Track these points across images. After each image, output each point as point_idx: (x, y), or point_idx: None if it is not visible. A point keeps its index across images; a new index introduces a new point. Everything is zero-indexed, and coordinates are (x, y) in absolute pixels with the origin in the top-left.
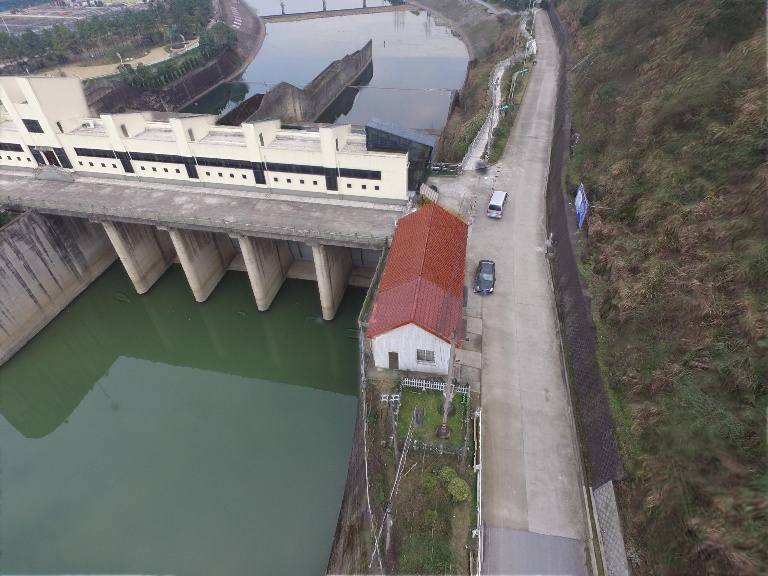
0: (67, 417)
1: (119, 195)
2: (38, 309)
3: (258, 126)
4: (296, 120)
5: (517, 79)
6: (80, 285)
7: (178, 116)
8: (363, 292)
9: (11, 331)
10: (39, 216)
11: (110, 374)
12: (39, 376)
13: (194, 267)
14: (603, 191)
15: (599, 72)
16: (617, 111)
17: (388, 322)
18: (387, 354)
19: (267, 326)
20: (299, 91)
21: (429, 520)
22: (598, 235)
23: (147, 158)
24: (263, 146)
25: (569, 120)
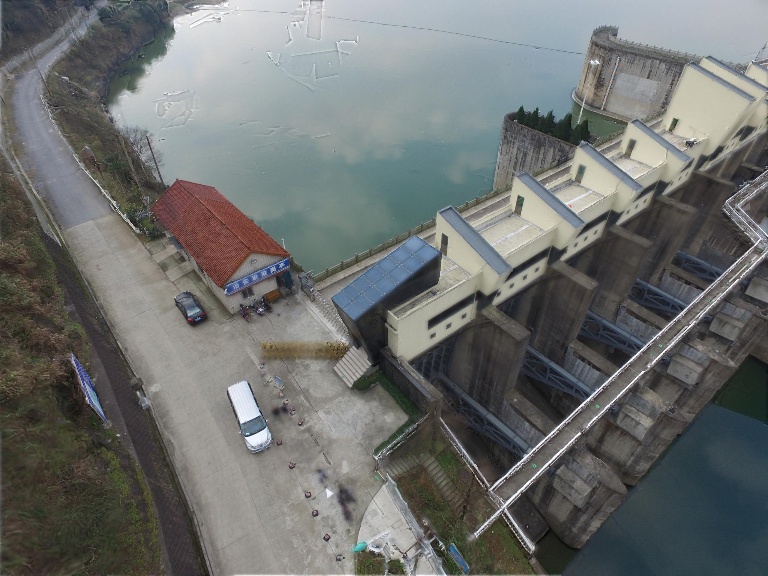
0: None
1: None
2: None
3: (522, 186)
4: None
5: None
6: None
7: None
8: None
9: None
10: None
11: None
12: None
13: None
14: None
15: None
16: None
17: None
18: None
19: None
20: None
21: None
22: None
23: None
24: None
25: None
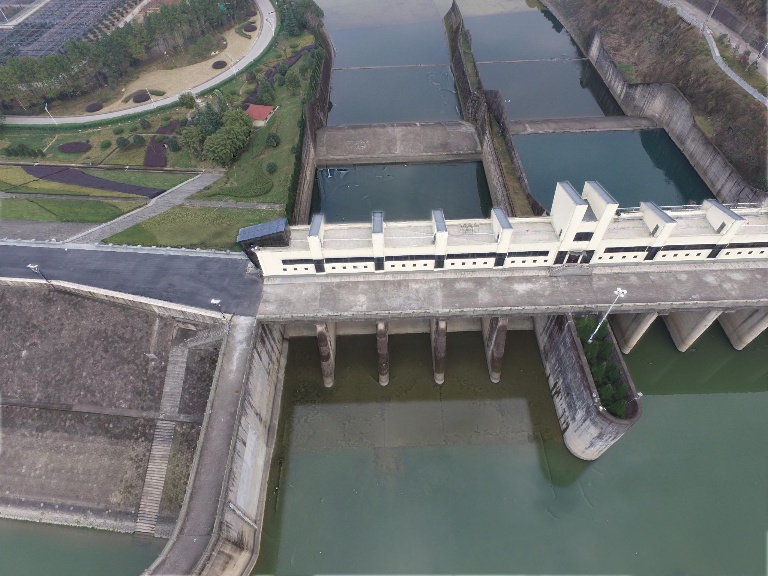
0: None
1: (654, 284)
2: None
3: None
4: None
5: None
6: None
7: (379, 134)
8: None
9: None
10: None
11: None
12: None
13: None
14: None
15: None
16: None
17: None
18: None
19: (729, 359)
20: None
21: None
22: None
23: (676, 248)
24: None
25: None
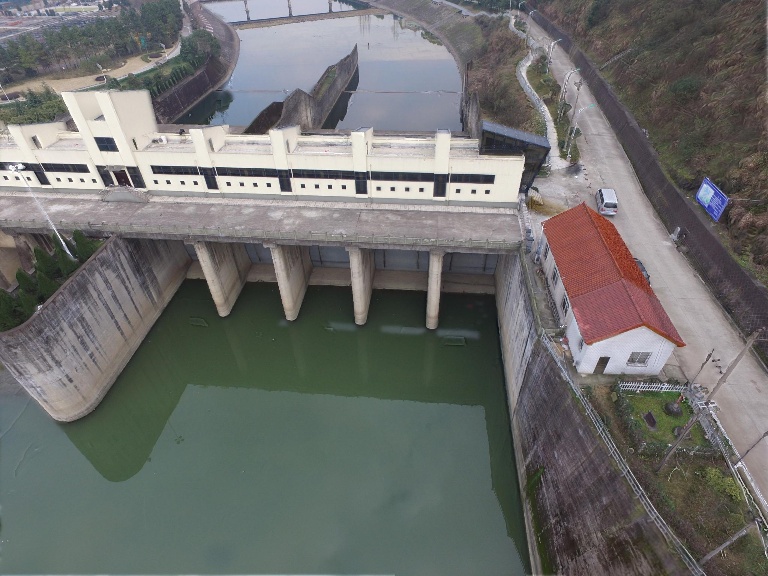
0: (149, 455)
1: (207, 214)
2: (124, 342)
3: (366, 134)
4: (308, 127)
5: (552, 79)
6: (155, 312)
7: (184, 128)
8: (456, 298)
9: (103, 368)
10: (122, 241)
11: (179, 404)
12: (126, 414)
13: (290, 284)
14: (736, 184)
15: (650, 69)
16: (709, 106)
17: (610, 327)
18: (597, 359)
19: (362, 340)
20: (309, 98)
21: (734, 523)
22: (748, 226)
23: (235, 173)
24: (370, 155)
25: (632, 117)
